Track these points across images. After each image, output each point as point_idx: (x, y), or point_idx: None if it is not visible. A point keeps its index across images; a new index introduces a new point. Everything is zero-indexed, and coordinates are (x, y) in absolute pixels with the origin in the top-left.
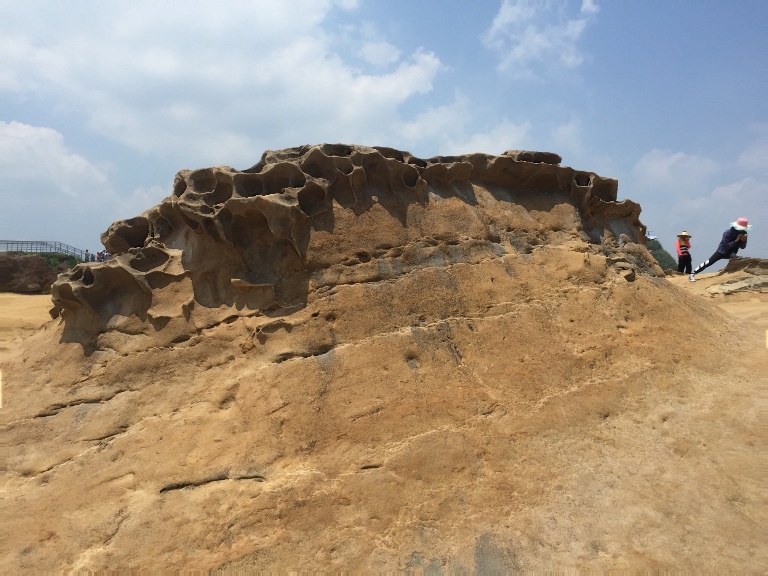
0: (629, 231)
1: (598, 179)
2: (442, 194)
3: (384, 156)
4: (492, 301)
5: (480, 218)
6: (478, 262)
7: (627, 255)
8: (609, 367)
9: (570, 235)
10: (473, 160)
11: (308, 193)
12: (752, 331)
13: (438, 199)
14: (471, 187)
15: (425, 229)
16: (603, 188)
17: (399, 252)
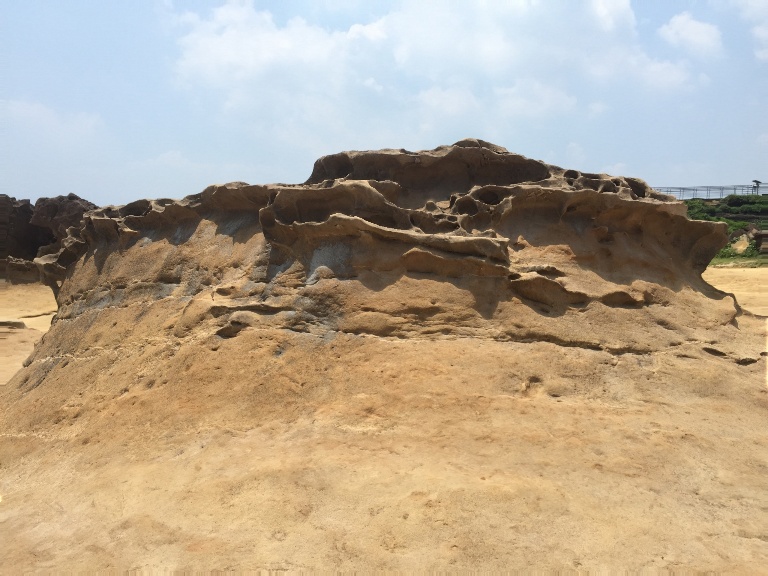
0: (344, 260)
1: (303, 192)
2: (157, 237)
3: (148, 206)
4: (93, 344)
5: (167, 259)
6: (127, 305)
7: (301, 298)
8: (62, 427)
9: (243, 272)
10: (208, 194)
11: (69, 251)
12: (274, 443)
13: (146, 244)
14: (198, 223)
15: (111, 275)
16: (349, 197)
17: (86, 296)
